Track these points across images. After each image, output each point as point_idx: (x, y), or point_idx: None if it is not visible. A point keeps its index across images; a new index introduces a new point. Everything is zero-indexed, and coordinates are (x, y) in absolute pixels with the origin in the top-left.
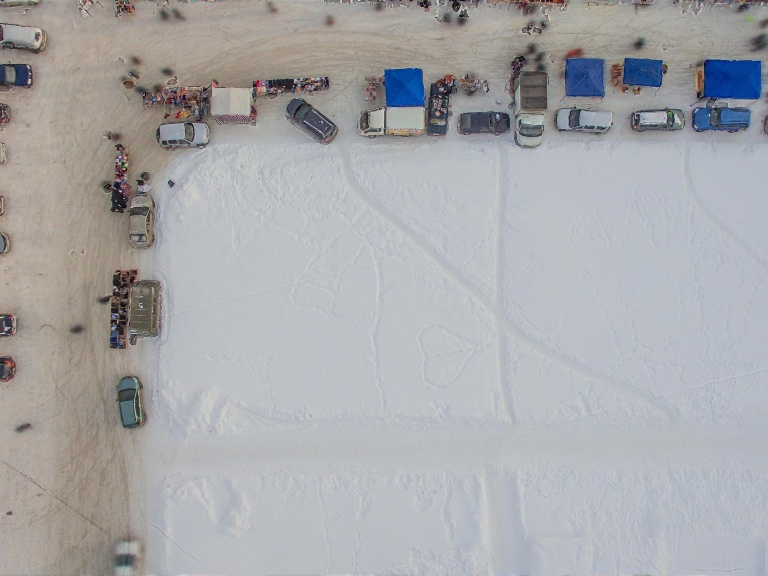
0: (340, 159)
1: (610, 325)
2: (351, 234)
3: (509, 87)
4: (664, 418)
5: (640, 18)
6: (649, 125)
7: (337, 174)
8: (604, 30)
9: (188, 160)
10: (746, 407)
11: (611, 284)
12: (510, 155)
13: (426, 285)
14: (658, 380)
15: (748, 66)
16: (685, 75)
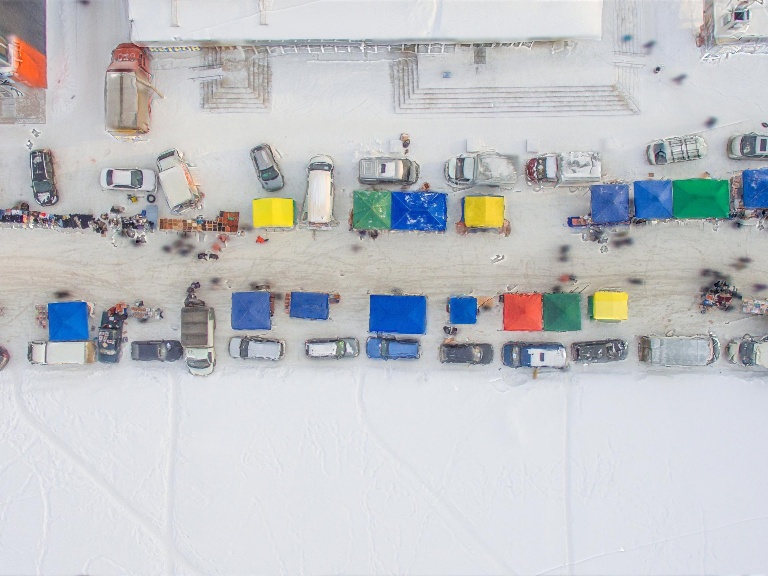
0: (12, 386)
1: (280, 555)
2: (20, 463)
3: None
4: None
5: (318, 244)
6: None
7: (8, 402)
8: (282, 256)
9: None
10: None
11: (281, 514)
12: (183, 383)
13: (94, 515)
14: None
15: (412, 302)
16: (362, 301)
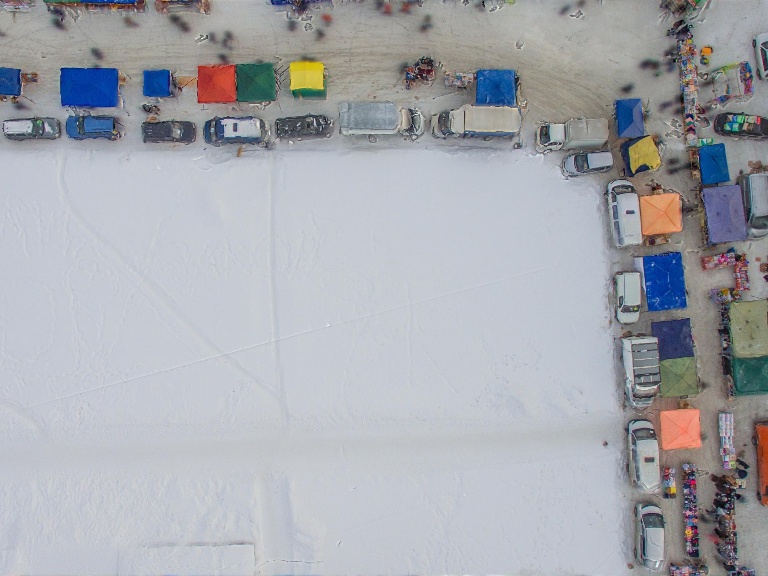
0: None
1: None
2: None
3: None
4: (30, 429)
5: (18, 26)
6: (16, 134)
7: None
8: None
9: None
10: (111, 417)
11: None
12: None
13: None
14: (27, 391)
15: (102, 74)
16: None
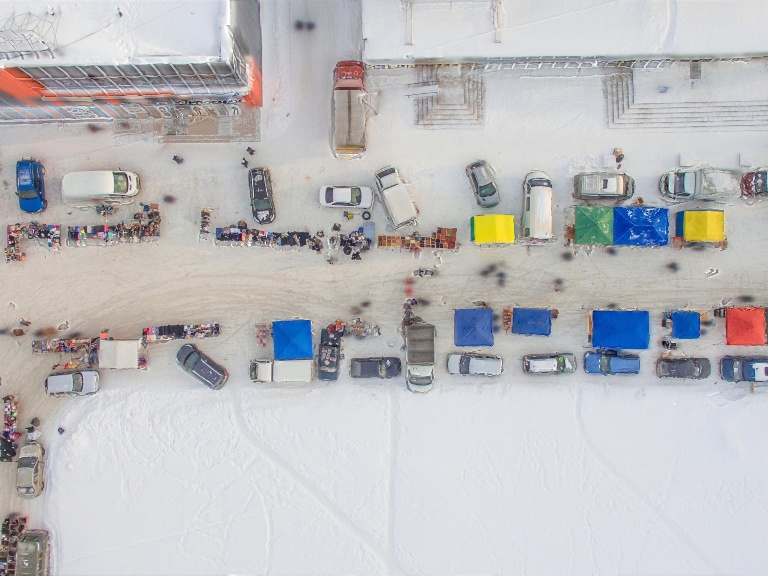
0: (231, 404)
1: (502, 571)
2: (241, 481)
3: (401, 329)
4: None
5: (532, 259)
6: (539, 371)
7: (228, 420)
8: (496, 271)
9: (78, 407)
10: None
11: (502, 531)
12: (401, 400)
13: (316, 533)
14: None
15: (636, 317)
16: (577, 316)
